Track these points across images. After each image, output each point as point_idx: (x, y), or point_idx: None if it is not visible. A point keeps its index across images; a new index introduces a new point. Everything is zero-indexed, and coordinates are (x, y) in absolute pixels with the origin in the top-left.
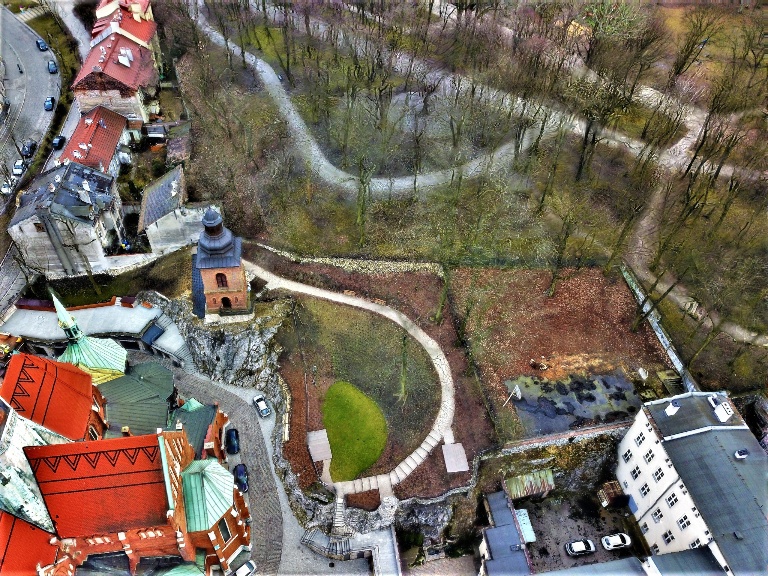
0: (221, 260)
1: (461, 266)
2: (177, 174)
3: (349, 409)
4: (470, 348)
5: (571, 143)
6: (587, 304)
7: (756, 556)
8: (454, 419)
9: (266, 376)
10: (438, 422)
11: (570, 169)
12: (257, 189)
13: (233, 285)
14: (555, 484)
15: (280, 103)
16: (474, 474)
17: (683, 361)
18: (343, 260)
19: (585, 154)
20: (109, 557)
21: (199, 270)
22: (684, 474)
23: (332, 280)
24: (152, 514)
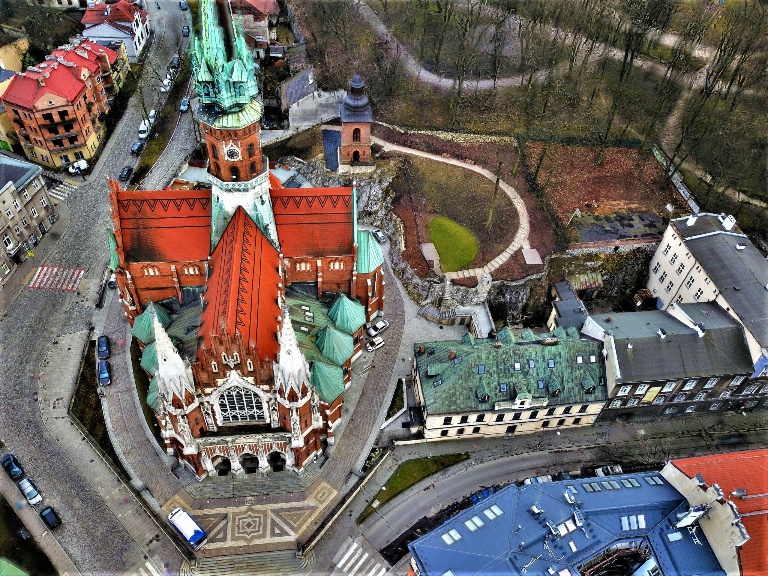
0: (360, 117)
1: (530, 141)
2: (310, 70)
3: (449, 232)
4: (539, 193)
5: (612, 65)
6: (626, 171)
7: (749, 298)
8: (529, 235)
9: (382, 216)
10: (518, 237)
11: (612, 81)
12: (369, 86)
13: (364, 140)
14: (602, 287)
15: (379, 30)
16: (546, 265)
17: (700, 205)
18: (441, 132)
19: (626, 64)
20: (305, 285)
21: (329, 140)
22: (699, 258)
23: (433, 146)
24: (342, 246)
